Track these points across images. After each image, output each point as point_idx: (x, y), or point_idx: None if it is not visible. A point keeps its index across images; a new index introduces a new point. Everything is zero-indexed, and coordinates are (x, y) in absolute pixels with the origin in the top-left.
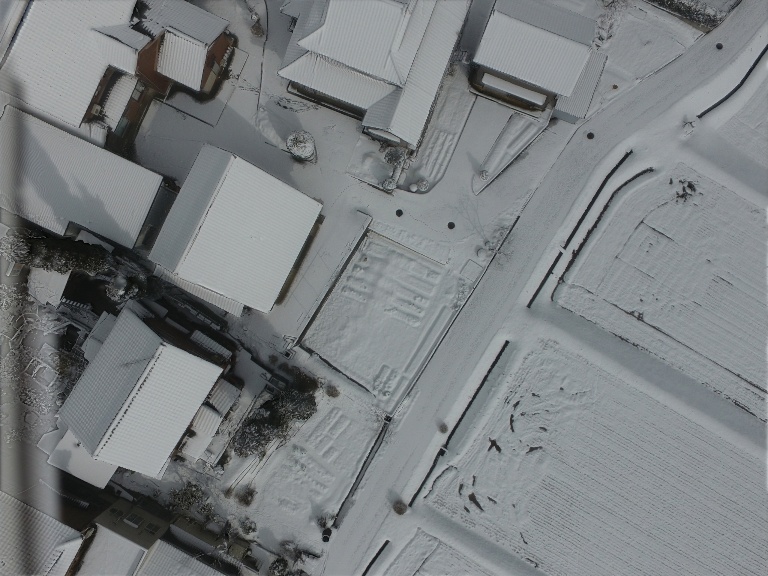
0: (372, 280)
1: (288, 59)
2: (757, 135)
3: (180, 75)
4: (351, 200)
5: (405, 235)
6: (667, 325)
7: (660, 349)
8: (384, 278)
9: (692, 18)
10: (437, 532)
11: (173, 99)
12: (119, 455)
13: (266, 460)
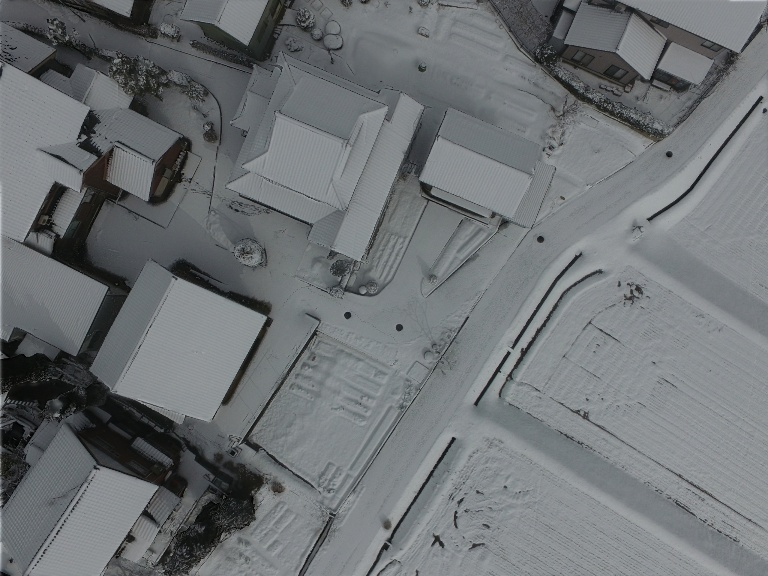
0: (320, 379)
1: (236, 173)
2: (706, 237)
3: (129, 186)
4: (300, 303)
5: (353, 337)
6: (612, 425)
7: (604, 448)
8: (332, 377)
9: (642, 129)
10: None
11: (125, 200)
12: (51, 573)
13: (210, 553)
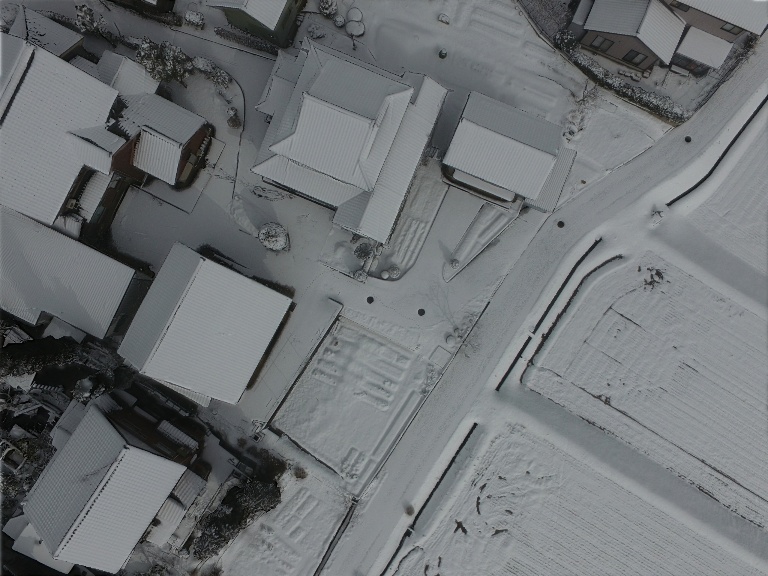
0: (342, 364)
1: (262, 157)
2: (725, 223)
3: (155, 170)
4: (323, 287)
5: (375, 322)
6: (633, 410)
7: (626, 433)
8: (354, 362)
9: (661, 114)
10: None
11: (150, 186)
12: (80, 554)
13: (233, 540)
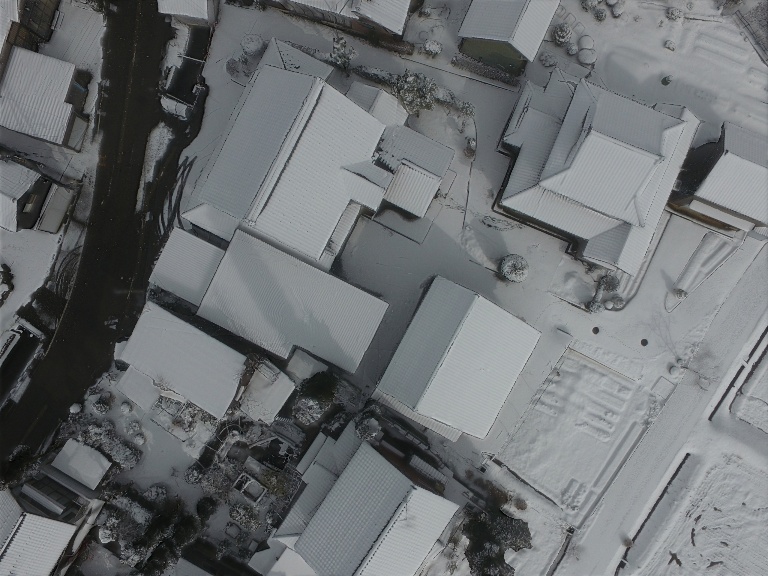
0: (563, 394)
1: (512, 189)
2: None
3: (406, 203)
4: (551, 318)
5: (601, 352)
6: None
7: None
8: (576, 393)
9: None
10: None
11: (381, 216)
12: None
13: None
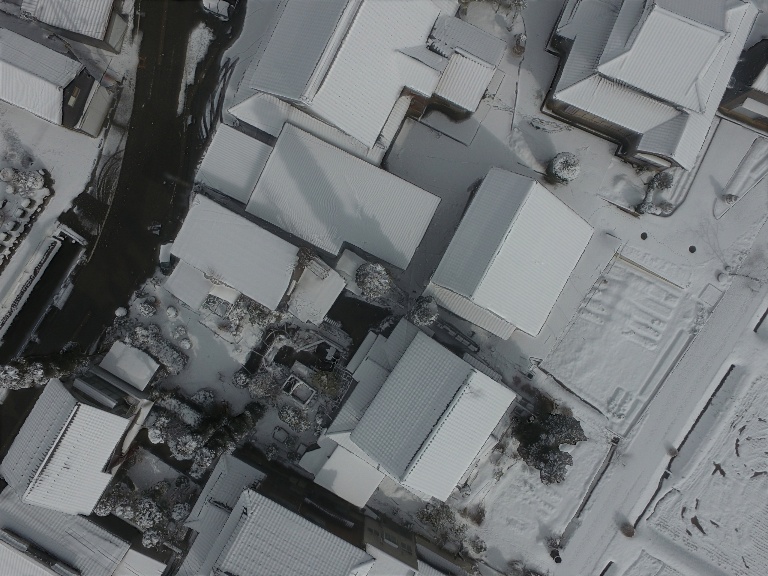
0: (610, 302)
1: (566, 82)
2: None
3: (457, 96)
4: (600, 222)
5: (649, 258)
6: None
7: None
8: (623, 301)
9: None
10: (663, 555)
11: (428, 117)
12: (421, 480)
13: None
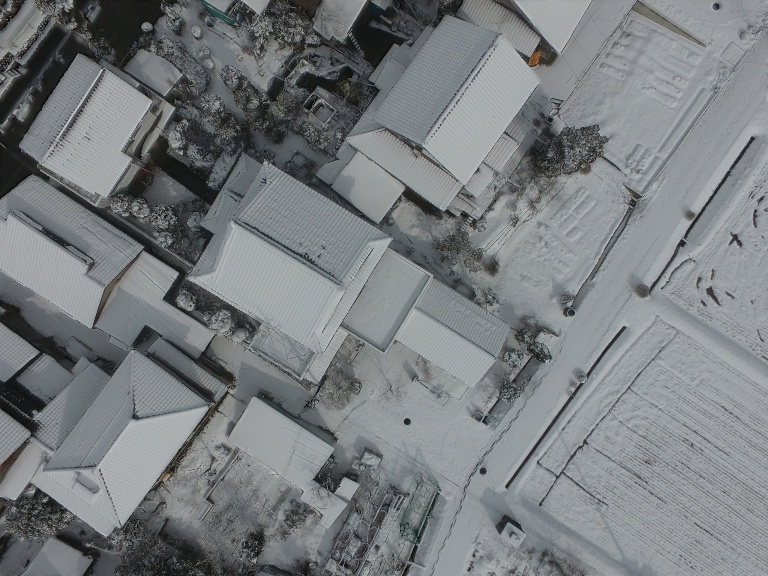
0: (632, 58)
1: None
2: None
3: None
4: None
5: (672, 10)
6: None
7: None
8: (645, 56)
9: None
10: (677, 320)
11: None
12: (443, 149)
13: (513, 233)
